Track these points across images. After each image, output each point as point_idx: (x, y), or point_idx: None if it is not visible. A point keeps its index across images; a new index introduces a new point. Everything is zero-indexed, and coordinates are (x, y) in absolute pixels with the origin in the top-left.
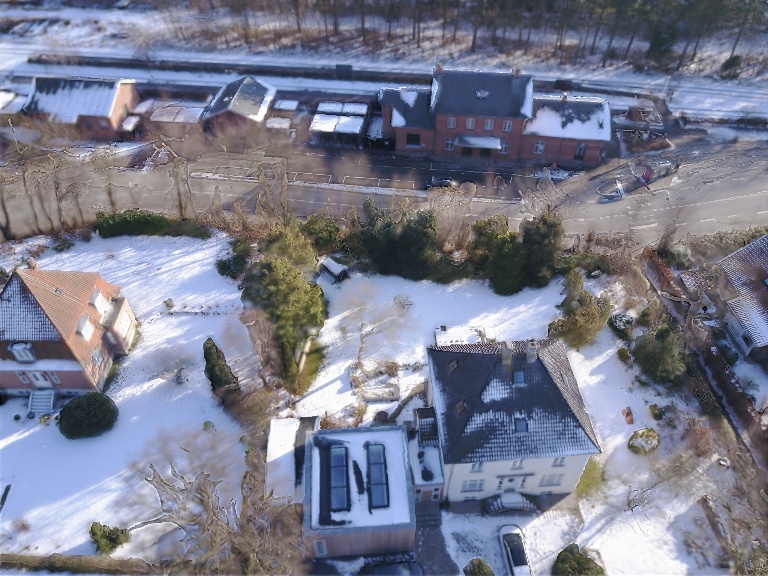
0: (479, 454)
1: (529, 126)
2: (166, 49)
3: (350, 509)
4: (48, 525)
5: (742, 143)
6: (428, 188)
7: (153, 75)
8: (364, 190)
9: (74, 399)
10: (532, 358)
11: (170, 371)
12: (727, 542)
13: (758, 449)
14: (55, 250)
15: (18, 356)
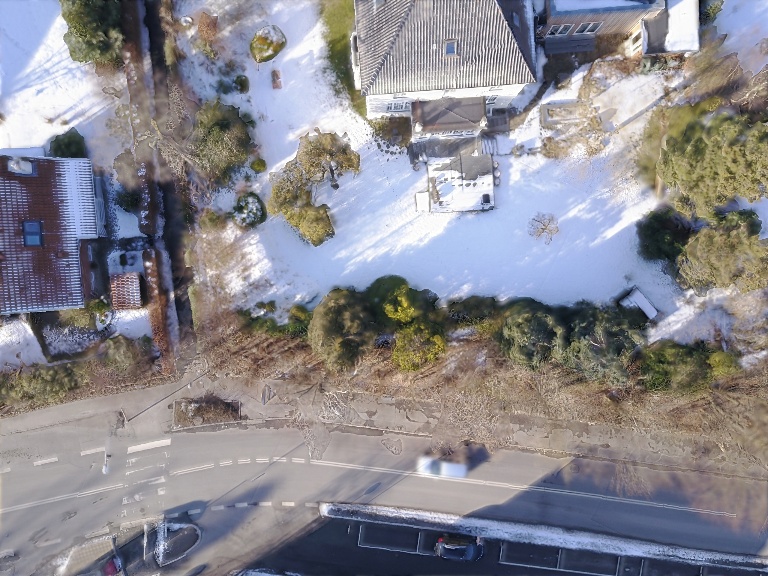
0: None
1: None
2: None
3: None
4: None
5: None
6: None
7: None
8: (584, 538)
9: None
10: None
11: None
12: None
13: None
14: None
15: None
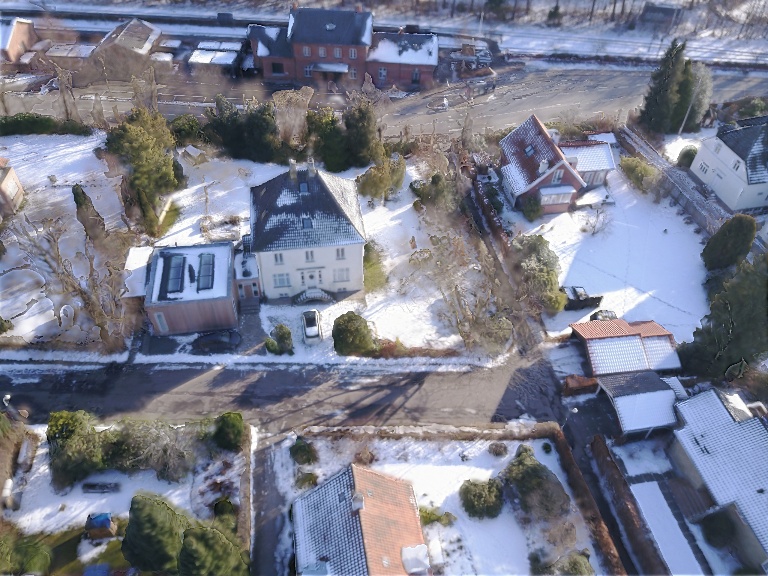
0: (277, 245)
1: (372, 54)
2: (65, 3)
3: (182, 291)
4: None
5: (551, 72)
6: None
7: (50, 20)
8: None
9: None
10: (312, 172)
11: None
12: (465, 310)
13: (506, 261)
14: None
15: None
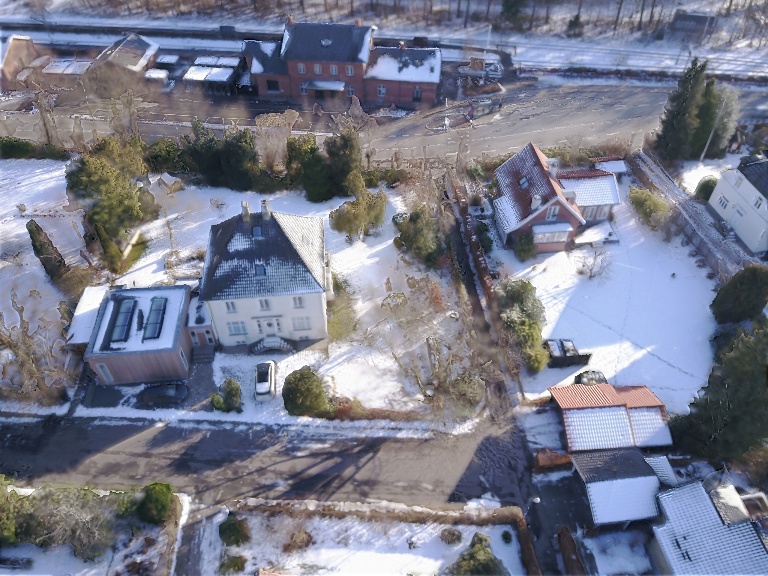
0: (226, 293)
1: (370, 71)
2: (73, 16)
3: (127, 340)
4: None
5: (565, 88)
6: None
7: None
8: (223, 127)
9: None
10: (266, 215)
11: (10, 255)
12: (434, 367)
13: (489, 308)
14: None
15: None
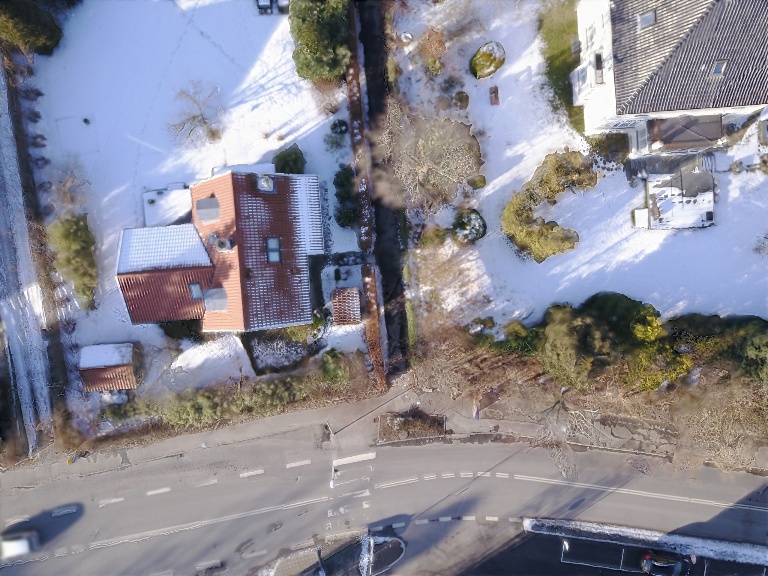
0: None
1: None
2: None
3: None
4: None
5: None
6: None
7: None
8: None
9: None
10: None
11: None
12: None
13: (357, 62)
14: None
15: None
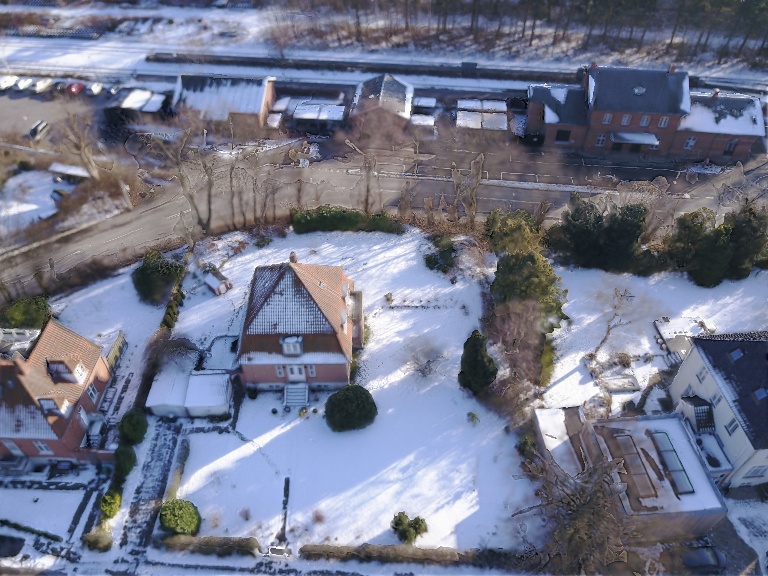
0: None
1: (683, 122)
2: None
3: (657, 495)
4: (340, 516)
5: None
6: (620, 183)
7: (283, 73)
8: (525, 186)
9: (340, 392)
10: None
11: None
12: None
13: None
14: (257, 246)
15: (286, 350)
